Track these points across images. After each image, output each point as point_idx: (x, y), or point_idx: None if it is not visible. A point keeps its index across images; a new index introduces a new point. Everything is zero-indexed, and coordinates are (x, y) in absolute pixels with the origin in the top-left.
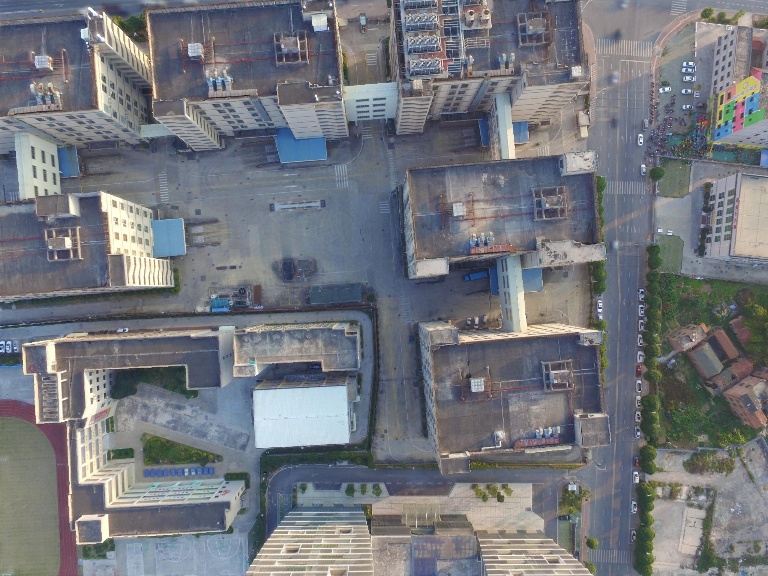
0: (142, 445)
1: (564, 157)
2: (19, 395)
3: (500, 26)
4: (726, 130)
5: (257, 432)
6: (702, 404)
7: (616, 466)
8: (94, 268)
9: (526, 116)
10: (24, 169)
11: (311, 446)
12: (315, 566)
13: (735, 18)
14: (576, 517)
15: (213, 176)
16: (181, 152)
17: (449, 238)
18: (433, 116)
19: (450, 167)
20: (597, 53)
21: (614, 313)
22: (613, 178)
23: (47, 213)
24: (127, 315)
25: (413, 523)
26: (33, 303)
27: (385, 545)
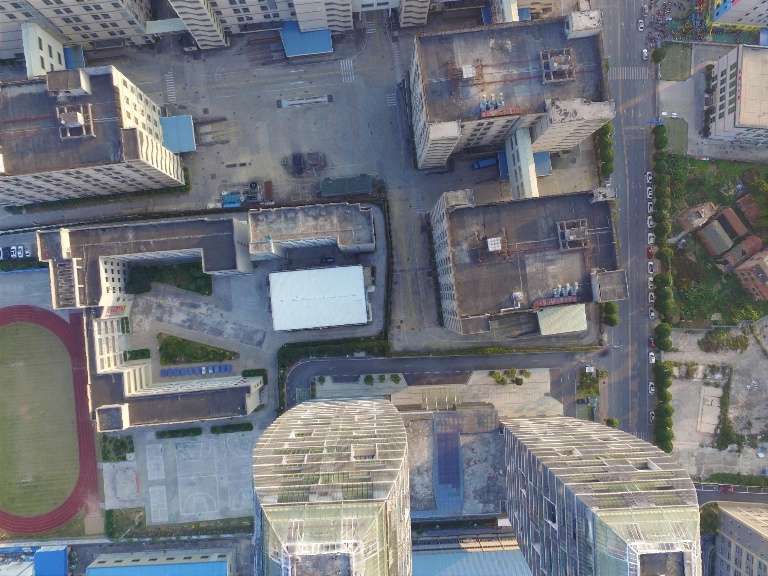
0: (158, 345)
1: (570, 17)
2: (32, 300)
3: None
4: (725, 7)
5: (275, 314)
6: (714, 282)
7: (632, 348)
8: (107, 145)
9: None
10: (32, 59)
11: (328, 340)
12: (342, 416)
13: None
14: (594, 400)
15: (219, 75)
16: (187, 51)
17: (459, 104)
18: (436, 5)
19: (457, 34)
20: None
21: (623, 197)
22: (616, 64)
23: (58, 88)
24: (138, 215)
25: (433, 407)
26: (43, 206)
27: (407, 422)
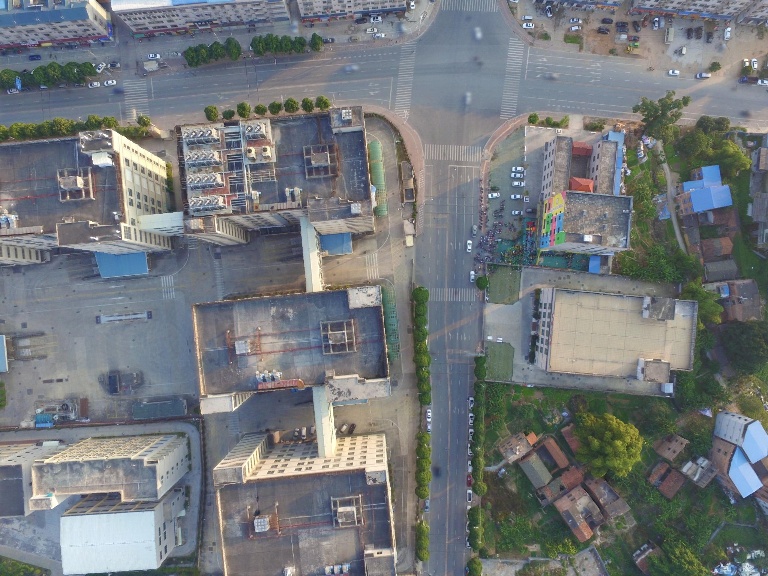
0: None
1: None
2: None
3: (287, 158)
4: (546, 242)
5: (64, 559)
6: (533, 514)
7: None
8: None
9: (343, 230)
10: None
11: None
12: None
13: (562, 123)
14: None
15: (39, 289)
16: (5, 266)
17: (237, 373)
18: (253, 229)
19: (238, 301)
20: (425, 159)
21: (444, 422)
22: (442, 285)
23: None
24: None
25: None
26: None
27: None
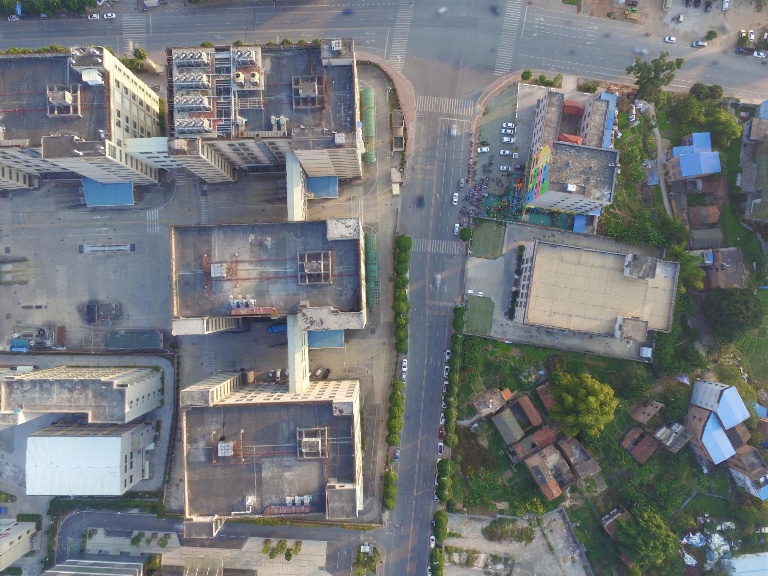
0: None
1: (326, 223)
2: None
3: (276, 87)
4: (531, 195)
5: (28, 479)
6: (503, 471)
7: (413, 529)
8: None
9: (329, 172)
10: None
11: None
12: None
13: (555, 82)
14: None
15: (25, 215)
16: None
17: (212, 297)
18: (241, 167)
19: (217, 226)
20: (417, 110)
21: (420, 373)
22: (426, 236)
23: None
24: None
25: None
26: None
27: None
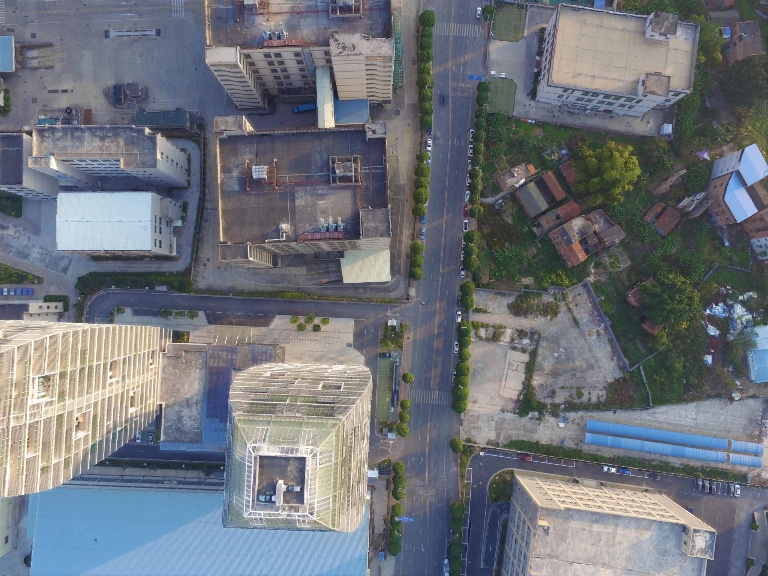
0: None
1: None
2: None
3: None
4: None
5: (59, 234)
6: (528, 246)
7: (440, 305)
8: None
9: None
10: None
11: (133, 272)
12: None
13: None
14: (397, 355)
15: (50, 1)
16: None
17: (244, 32)
18: None
19: None
20: None
21: (444, 152)
22: (449, 20)
23: None
24: None
25: None
26: None
27: (180, 352)
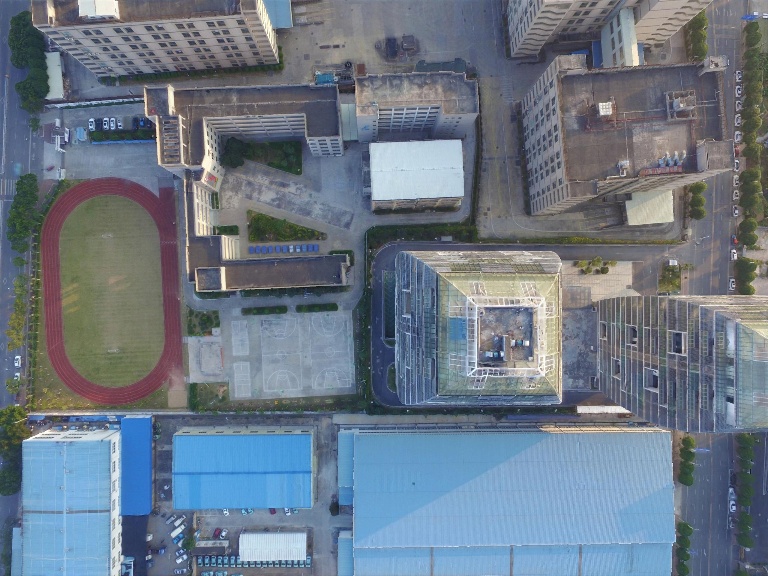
0: (247, 222)
1: None
2: (123, 173)
3: None
4: None
5: (374, 184)
6: None
7: (714, 245)
8: None
9: None
10: None
11: (415, 224)
12: None
13: None
14: None
15: None
16: None
17: None
18: None
19: None
20: None
21: None
22: None
23: None
24: None
25: None
26: (137, 79)
27: None
